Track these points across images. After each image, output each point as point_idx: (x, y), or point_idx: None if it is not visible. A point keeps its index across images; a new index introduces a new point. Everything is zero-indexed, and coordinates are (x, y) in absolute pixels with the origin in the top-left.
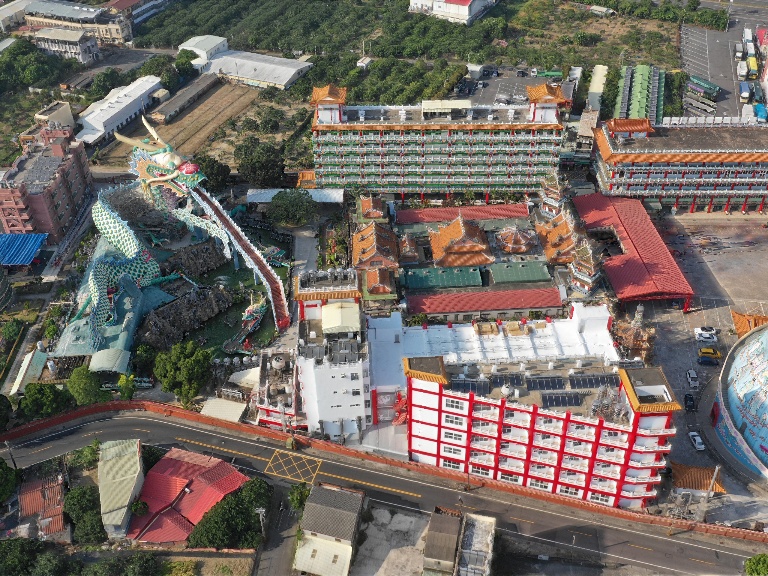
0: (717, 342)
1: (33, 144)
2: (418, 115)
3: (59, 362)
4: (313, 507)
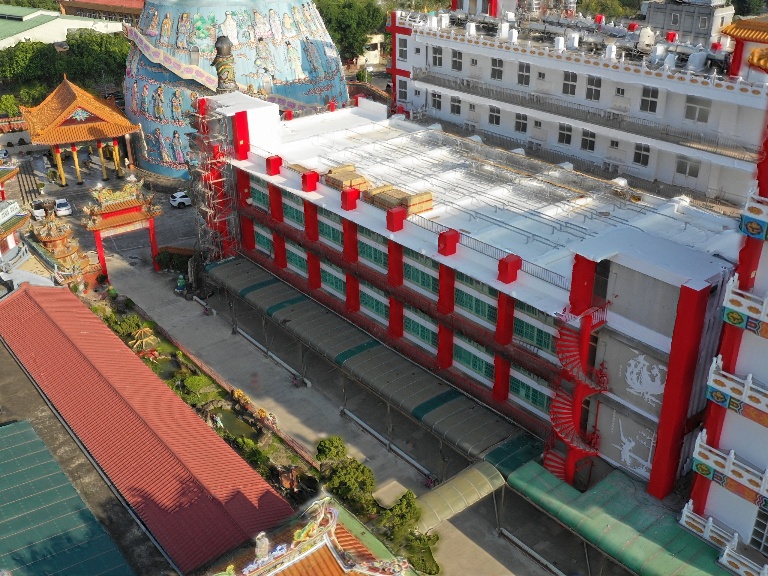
0: None
1: None
2: None
3: None
4: None
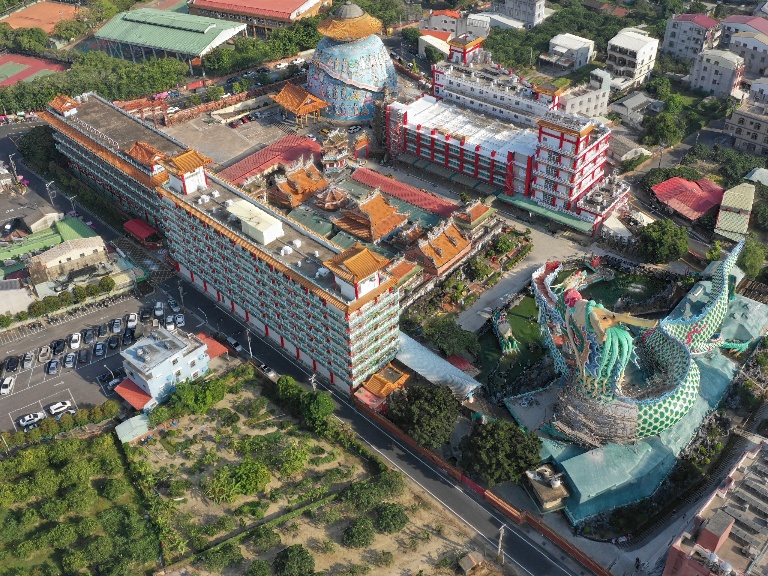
0: None
1: None
2: (276, 243)
3: (767, 301)
4: (632, 146)
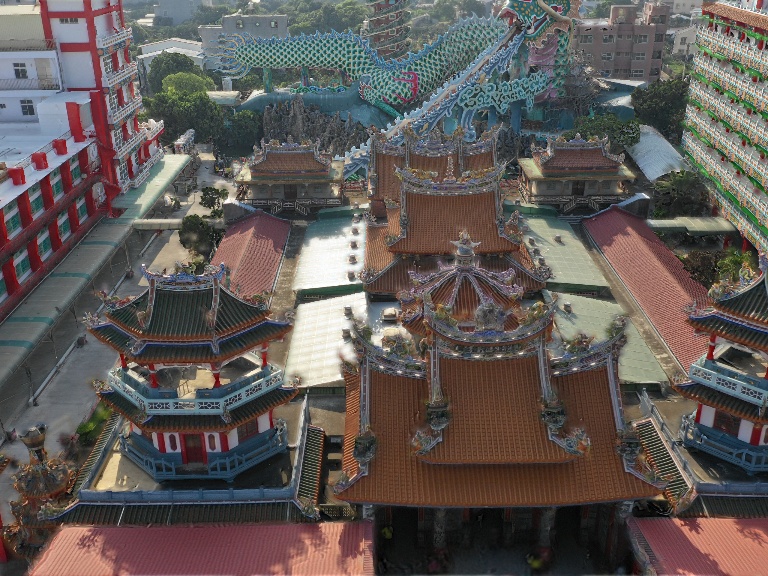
0: None
1: (636, 19)
2: None
3: None
4: None
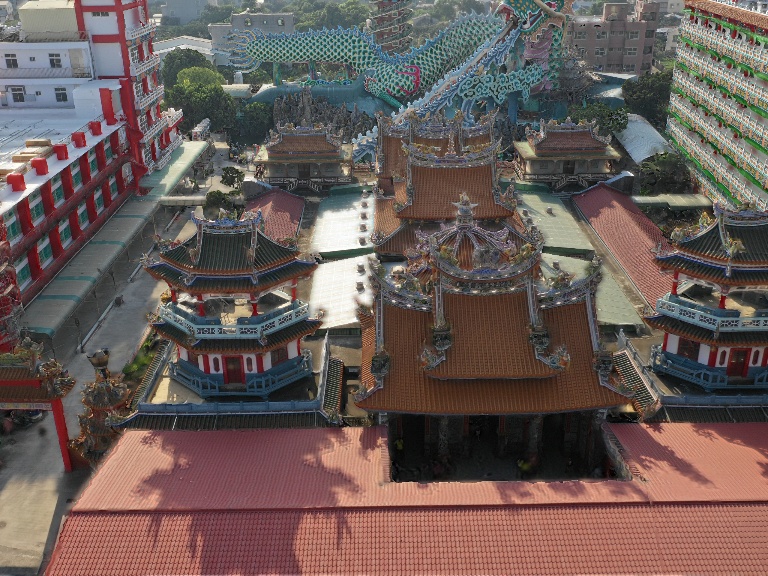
0: None
1: (628, 17)
2: None
3: None
4: None
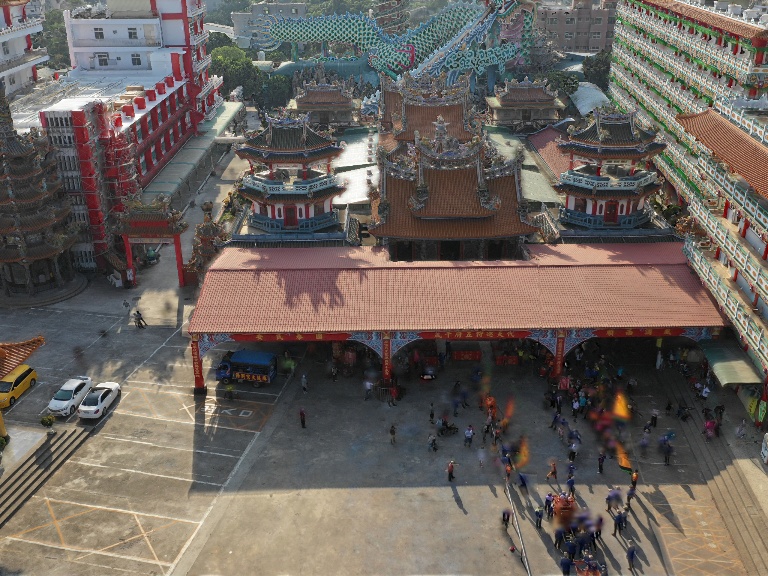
0: (48, 412)
1: (595, 6)
2: None
3: None
4: None
